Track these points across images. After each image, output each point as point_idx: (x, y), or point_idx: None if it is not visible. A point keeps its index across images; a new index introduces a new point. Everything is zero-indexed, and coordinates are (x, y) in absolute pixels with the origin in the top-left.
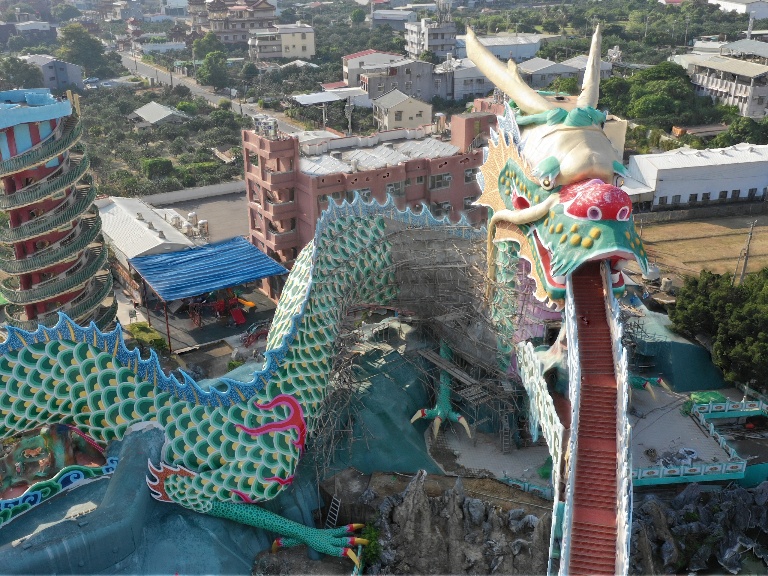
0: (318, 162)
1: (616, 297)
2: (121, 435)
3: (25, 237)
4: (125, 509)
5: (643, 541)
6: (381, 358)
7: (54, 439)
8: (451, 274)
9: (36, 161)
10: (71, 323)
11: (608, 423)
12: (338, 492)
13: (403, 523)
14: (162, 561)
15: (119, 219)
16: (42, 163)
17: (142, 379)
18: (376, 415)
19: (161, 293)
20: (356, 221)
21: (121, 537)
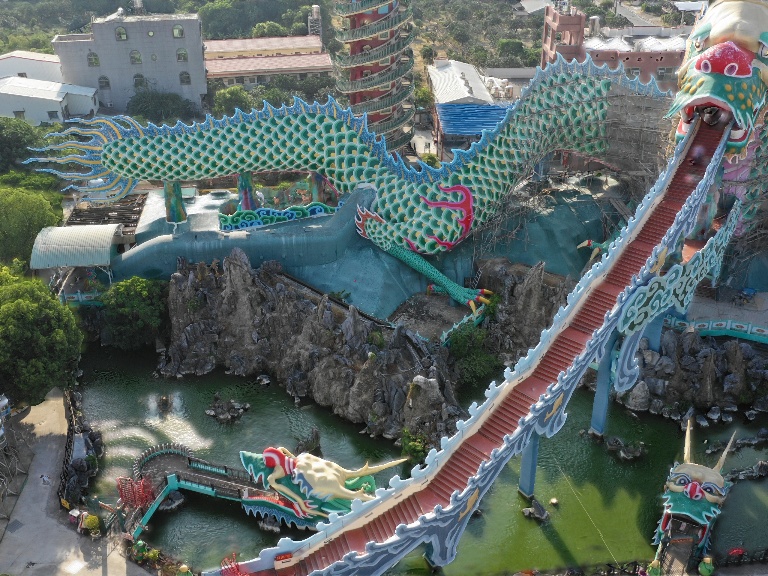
0: (608, 42)
1: (732, 151)
2: (352, 189)
3: (354, 64)
4: (335, 230)
5: (707, 364)
6: (575, 197)
7: (313, 183)
8: (657, 139)
9: (370, 6)
10: (336, 105)
11: (663, 235)
12: (485, 267)
13: (518, 296)
14: (350, 271)
15: (448, 76)
16: (374, 8)
17: (374, 155)
18: (543, 229)
19: (444, 128)
20: (581, 78)
21: (329, 247)
